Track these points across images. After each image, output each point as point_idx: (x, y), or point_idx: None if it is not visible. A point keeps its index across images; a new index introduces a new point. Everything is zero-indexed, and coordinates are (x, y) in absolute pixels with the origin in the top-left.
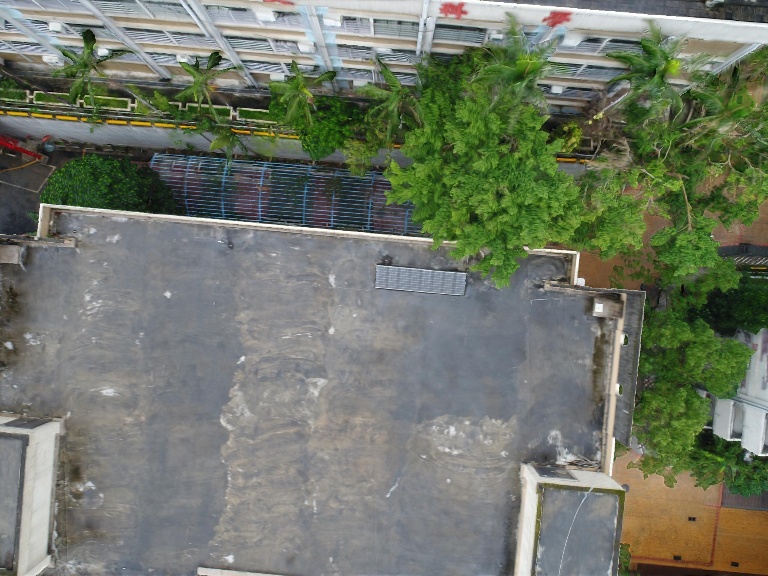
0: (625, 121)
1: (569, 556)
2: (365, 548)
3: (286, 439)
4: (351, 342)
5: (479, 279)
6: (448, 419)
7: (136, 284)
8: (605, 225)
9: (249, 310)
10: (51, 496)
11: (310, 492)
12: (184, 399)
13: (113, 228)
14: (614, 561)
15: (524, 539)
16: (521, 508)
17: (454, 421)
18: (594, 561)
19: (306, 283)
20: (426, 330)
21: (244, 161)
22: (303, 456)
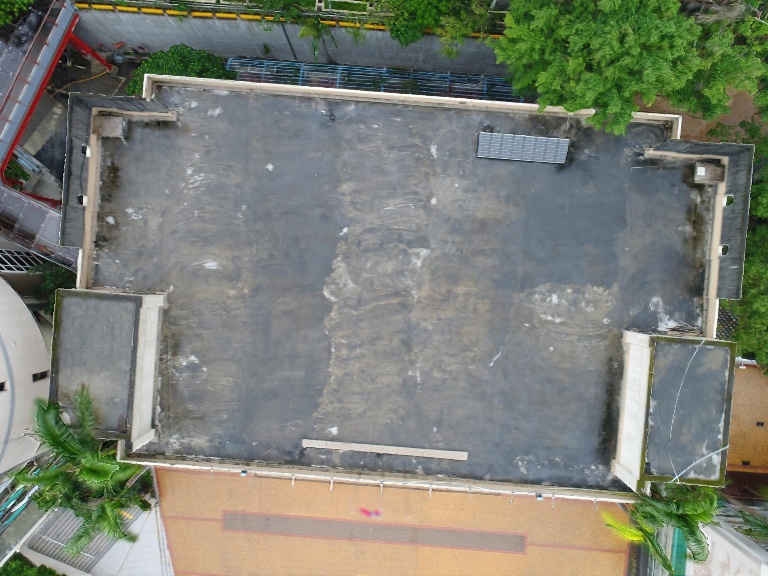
0: (713, 0)
1: (681, 410)
2: (469, 417)
3: (389, 310)
4: (453, 212)
5: (579, 148)
6: (550, 287)
7: (238, 157)
8: (717, 76)
9: (351, 181)
10: (155, 370)
11: (414, 362)
12: (287, 271)
13: (214, 101)
14: (726, 413)
15: (629, 403)
16: (624, 374)
17: (556, 289)
18: (706, 414)
19: (408, 154)
20: (527, 199)
21: (319, 65)
22: (406, 326)
